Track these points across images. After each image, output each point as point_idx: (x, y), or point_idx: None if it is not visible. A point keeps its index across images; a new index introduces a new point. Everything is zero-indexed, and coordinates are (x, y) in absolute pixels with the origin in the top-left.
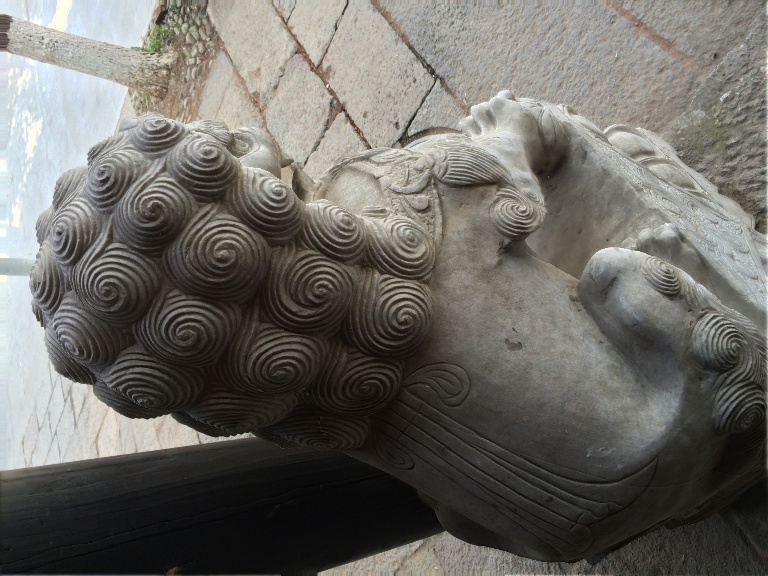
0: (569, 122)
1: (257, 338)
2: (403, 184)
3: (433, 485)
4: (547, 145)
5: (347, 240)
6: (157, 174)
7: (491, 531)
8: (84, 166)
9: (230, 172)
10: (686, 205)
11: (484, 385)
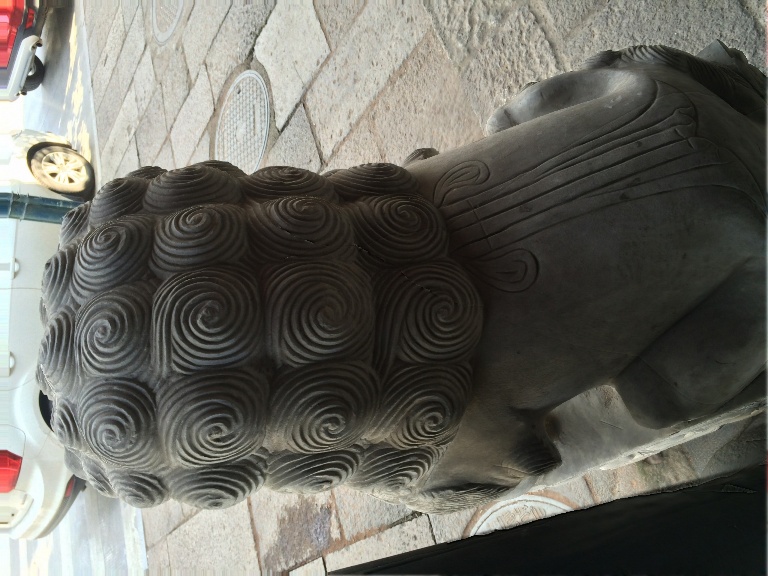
0: None
1: (266, 205)
2: None
3: (571, 254)
4: None
5: None
6: None
7: (726, 319)
8: None
9: None
10: None
11: (487, 152)
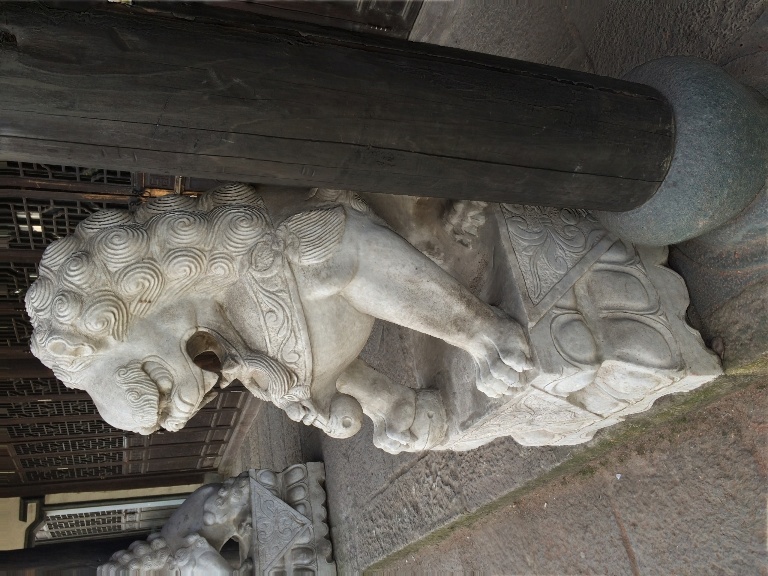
0: None
1: None
2: None
3: None
4: None
5: None
6: None
7: None
8: None
9: None
10: None
11: None
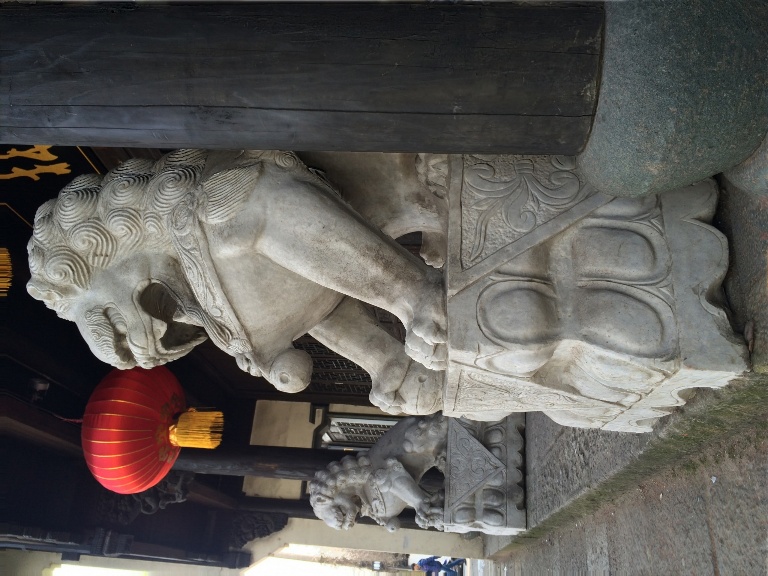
0: None
1: None
2: None
3: None
4: None
5: None
6: None
7: None
8: None
9: None
10: None
11: None
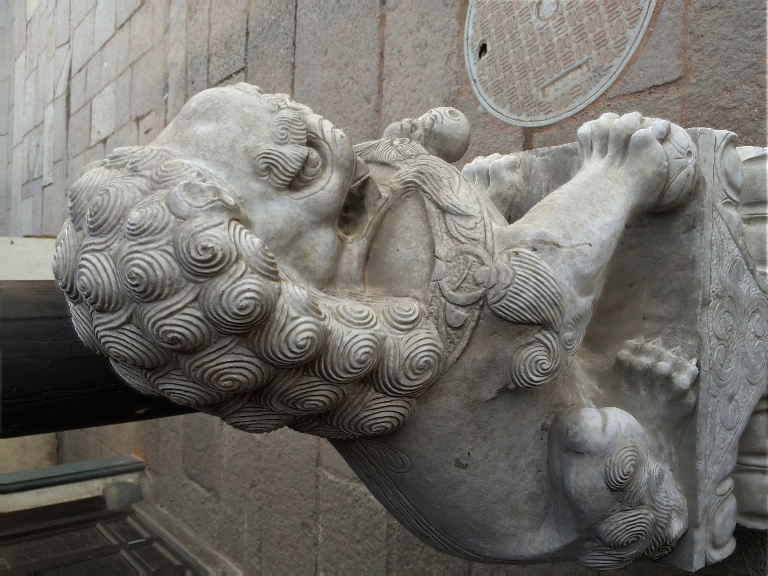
0: (706, 182)
1: (241, 410)
2: (453, 288)
3: None
4: (660, 205)
5: (354, 374)
6: (186, 304)
7: None
8: (126, 195)
9: (261, 319)
10: (746, 315)
11: (420, 476)
